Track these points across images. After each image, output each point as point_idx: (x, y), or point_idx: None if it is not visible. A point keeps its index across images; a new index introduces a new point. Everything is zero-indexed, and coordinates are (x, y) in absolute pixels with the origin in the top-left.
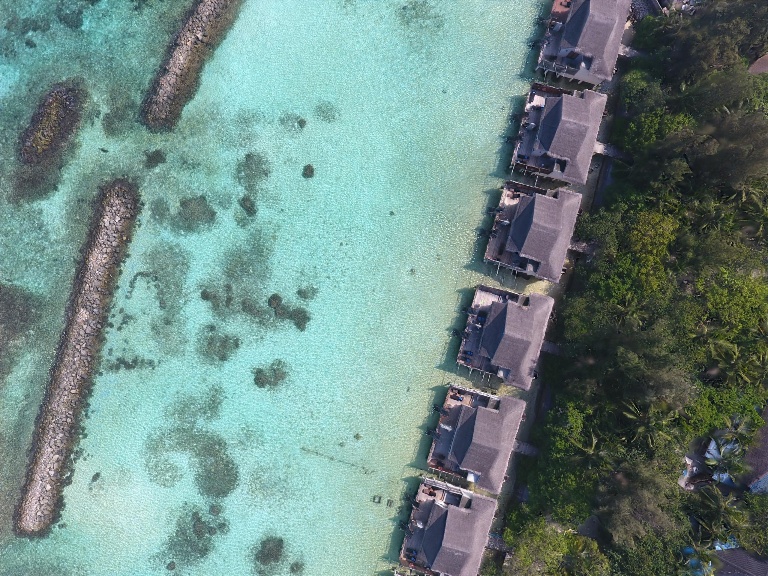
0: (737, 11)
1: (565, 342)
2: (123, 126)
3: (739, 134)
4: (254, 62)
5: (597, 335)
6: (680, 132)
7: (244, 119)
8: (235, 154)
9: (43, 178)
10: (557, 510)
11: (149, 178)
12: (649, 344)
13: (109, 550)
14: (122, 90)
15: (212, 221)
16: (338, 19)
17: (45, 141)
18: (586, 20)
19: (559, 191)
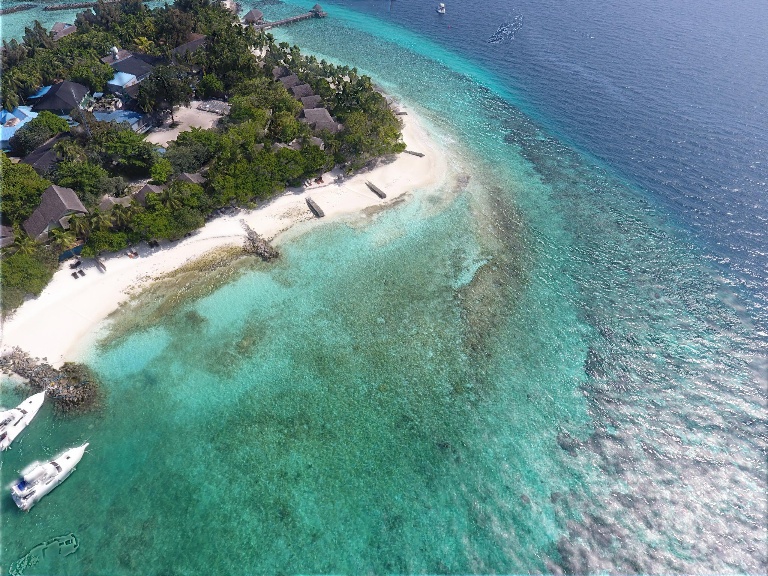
0: None
1: None
2: None
3: None
4: None
5: None
6: None
7: None
8: None
9: None
10: None
11: None
12: None
13: None
14: None
15: None
16: (3, 26)
17: None
18: None
19: None
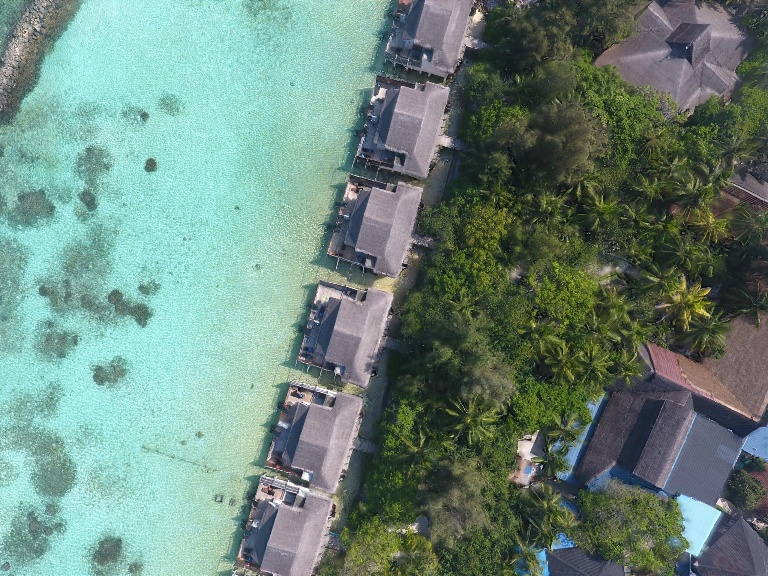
0: (564, 1)
1: (403, 338)
2: None
3: (558, 126)
4: (96, 54)
5: (430, 331)
6: (503, 124)
7: (85, 112)
8: (75, 148)
9: None
10: (386, 509)
11: None
12: (464, 340)
13: None
14: None
15: (51, 216)
16: (183, 11)
17: None
18: (423, 11)
19: (398, 185)
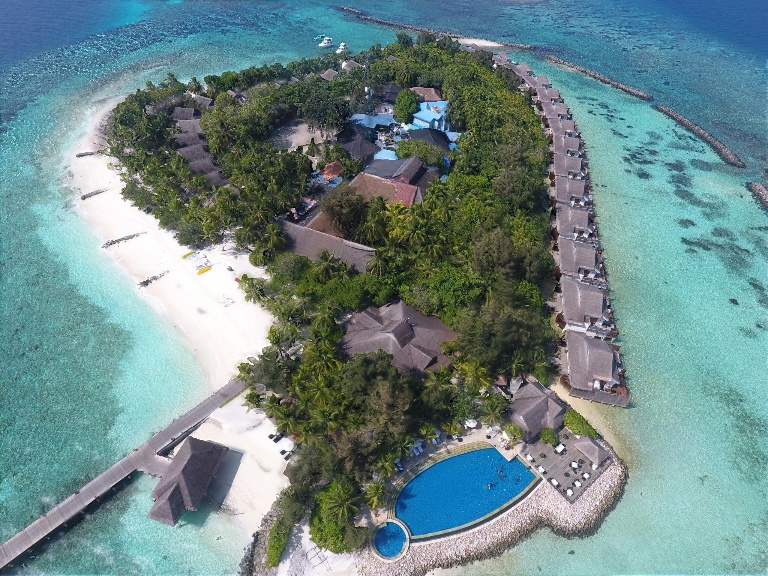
0: None
1: None
2: None
3: None
4: None
5: None
6: None
7: None
8: None
9: None
10: None
11: None
12: None
13: None
14: None
15: None
16: None
17: None
18: None
19: None
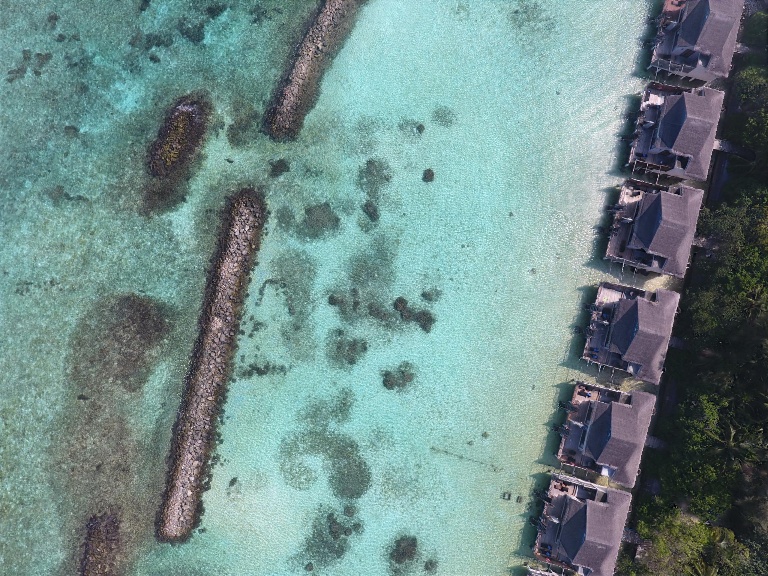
0: None
1: (693, 336)
2: (247, 137)
3: None
4: (372, 70)
5: (729, 328)
6: None
7: (364, 126)
8: (357, 161)
9: (172, 190)
10: (697, 502)
11: (274, 187)
12: None
13: (249, 553)
14: (245, 101)
15: (336, 227)
16: (452, 25)
17: (173, 154)
18: (705, 19)
19: (682, 188)
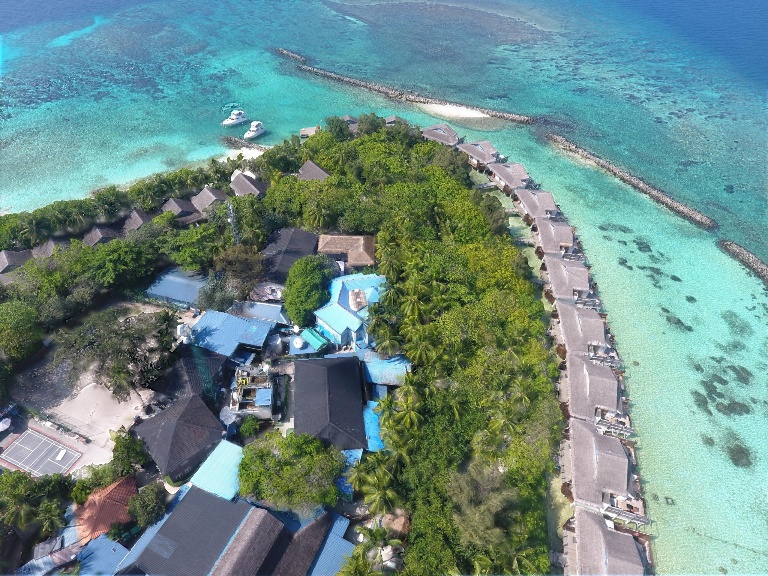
0: None
1: None
2: None
3: None
4: None
5: None
6: None
7: None
8: None
9: None
10: None
11: None
12: None
13: None
14: None
15: None
16: None
17: None
18: None
19: None
